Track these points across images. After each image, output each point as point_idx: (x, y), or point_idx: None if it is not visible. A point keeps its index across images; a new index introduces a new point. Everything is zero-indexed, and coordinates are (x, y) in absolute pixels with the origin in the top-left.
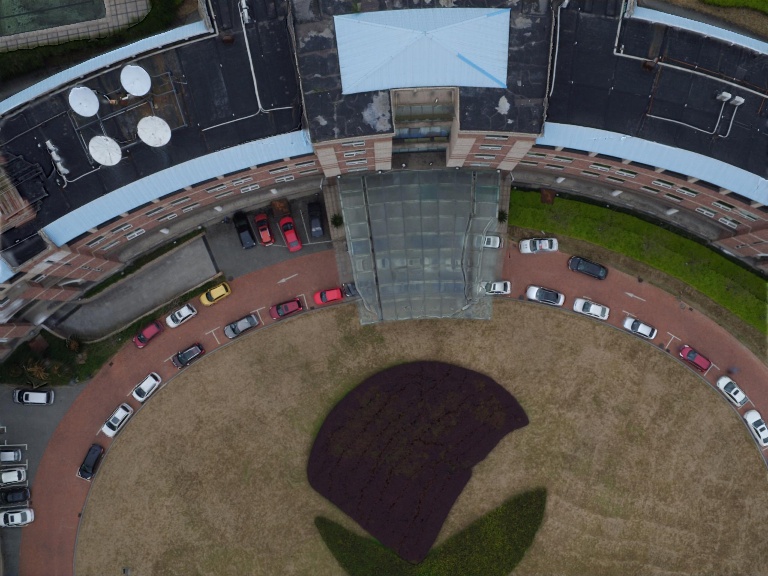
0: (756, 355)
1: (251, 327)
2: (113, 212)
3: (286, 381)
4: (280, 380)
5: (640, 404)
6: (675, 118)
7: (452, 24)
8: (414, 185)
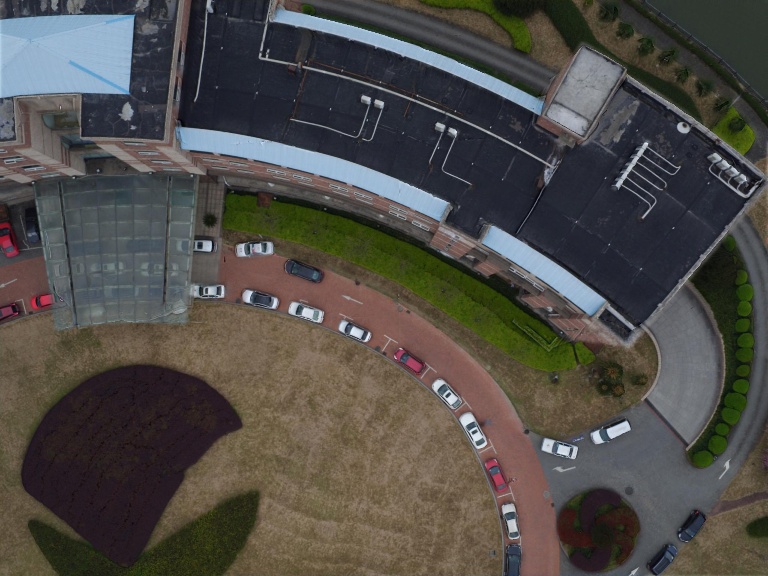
0: (473, 357)
1: None
2: None
3: (4, 386)
4: None
5: (355, 407)
6: (320, 122)
7: (62, 31)
8: (109, 190)
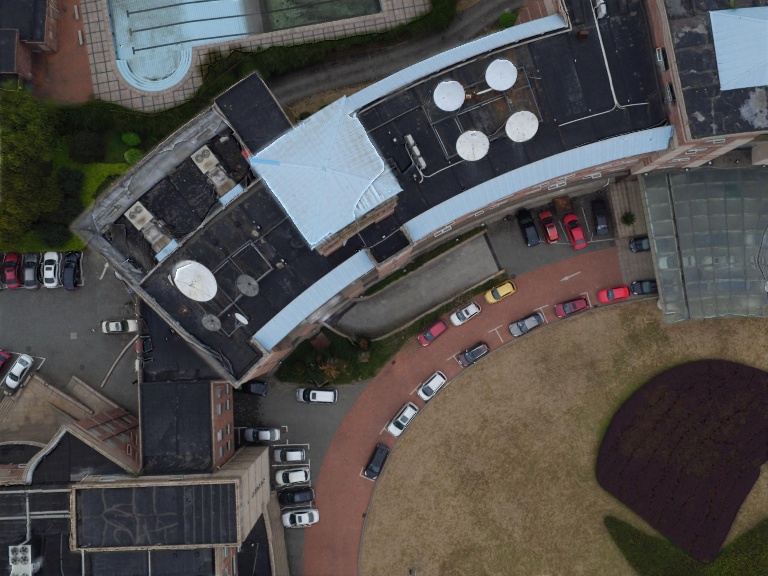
0: None
1: (538, 325)
2: (468, 208)
3: (571, 380)
4: (565, 379)
5: None
6: None
7: None
8: (719, 183)
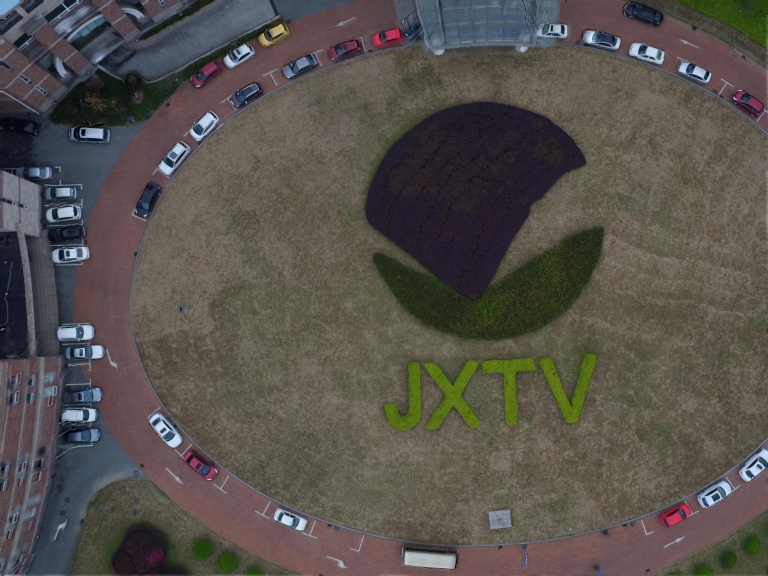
0: None
1: (310, 66)
2: None
3: (344, 122)
4: (338, 121)
5: (694, 148)
6: None
7: None
8: None
